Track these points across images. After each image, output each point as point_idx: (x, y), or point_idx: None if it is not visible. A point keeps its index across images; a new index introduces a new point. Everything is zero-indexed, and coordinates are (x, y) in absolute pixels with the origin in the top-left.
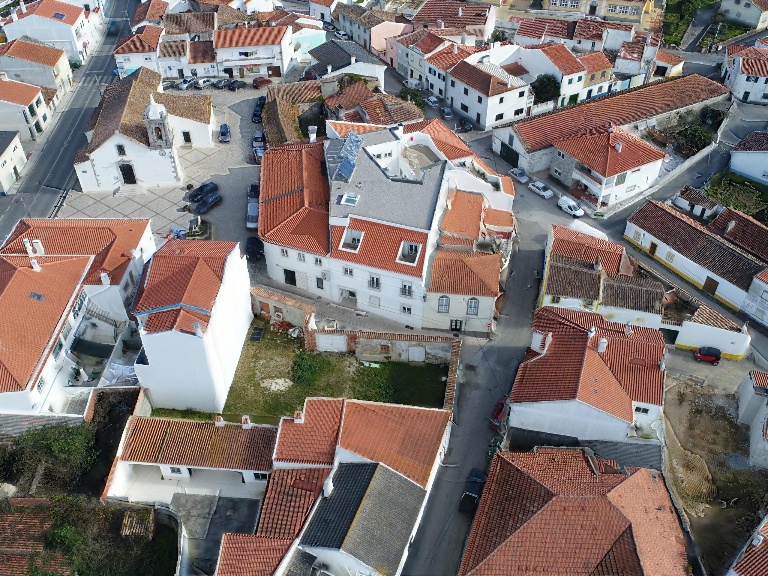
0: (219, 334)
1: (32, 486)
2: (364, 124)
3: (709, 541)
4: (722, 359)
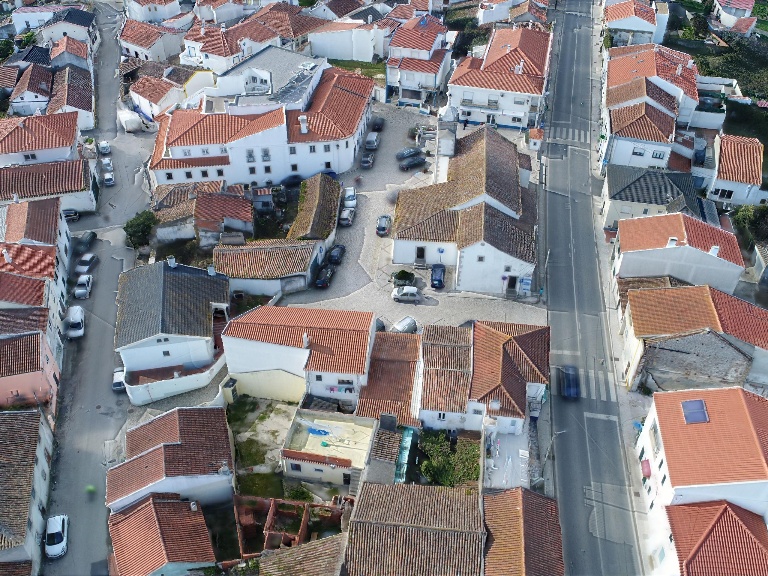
0: None
1: None
2: (247, 137)
3: None
4: None
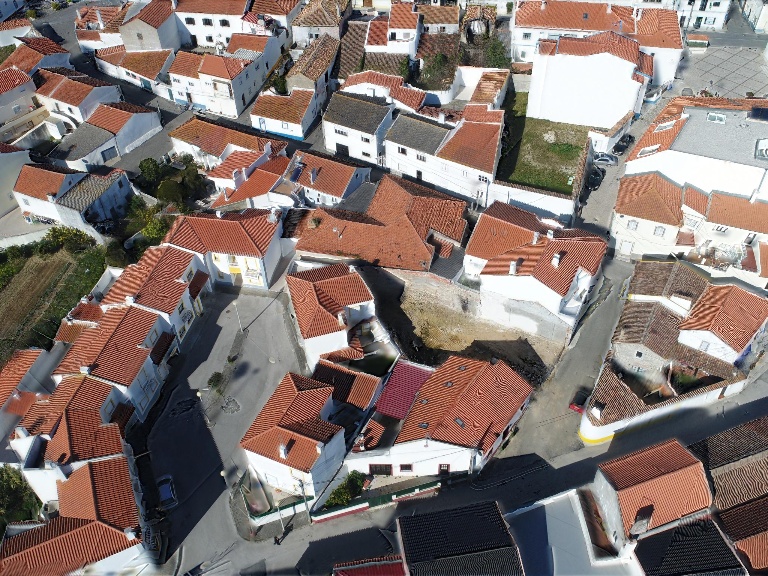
0: (557, 76)
1: (470, 49)
2: None
3: (378, 291)
4: (579, 419)
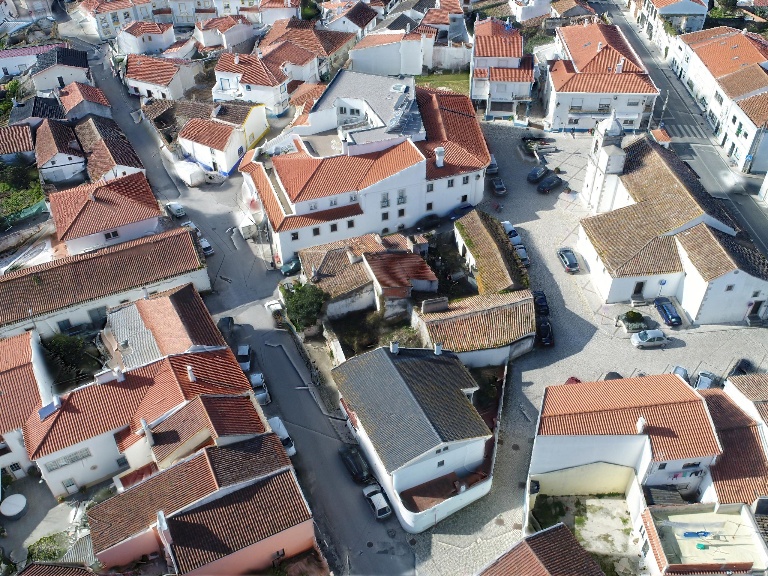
0: None
1: None
2: (384, 180)
3: None
4: None
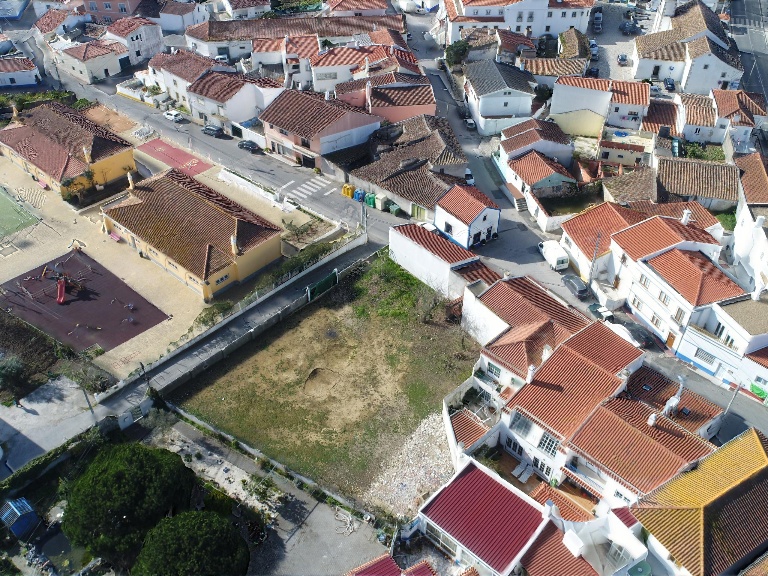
0: None
1: None
2: (521, 2)
3: None
4: None
